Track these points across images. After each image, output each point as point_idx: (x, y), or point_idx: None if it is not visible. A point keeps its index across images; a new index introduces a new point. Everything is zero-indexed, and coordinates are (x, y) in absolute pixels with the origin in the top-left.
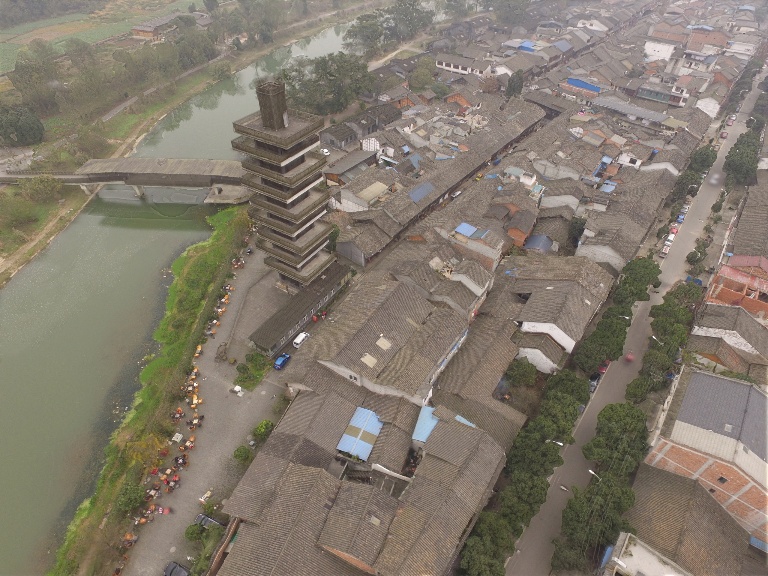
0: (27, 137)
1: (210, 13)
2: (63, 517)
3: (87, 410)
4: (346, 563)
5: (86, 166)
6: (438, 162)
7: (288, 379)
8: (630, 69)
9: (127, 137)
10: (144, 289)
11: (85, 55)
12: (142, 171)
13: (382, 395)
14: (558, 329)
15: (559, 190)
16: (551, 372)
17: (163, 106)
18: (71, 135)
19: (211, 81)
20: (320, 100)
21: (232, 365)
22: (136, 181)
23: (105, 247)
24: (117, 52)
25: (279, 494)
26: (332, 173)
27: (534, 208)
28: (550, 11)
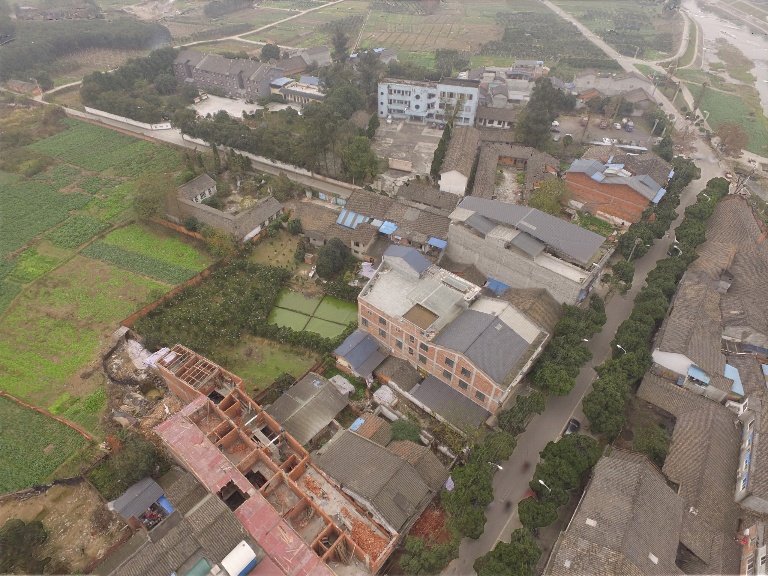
0: None
1: None
2: None
3: None
4: None
5: None
6: None
7: None
8: None
9: None
10: None
11: None
12: None
13: None
14: None
15: None
16: None
17: None
18: None
19: None
20: None
21: None
22: None
23: None
24: None
25: None
26: None
27: None
28: None
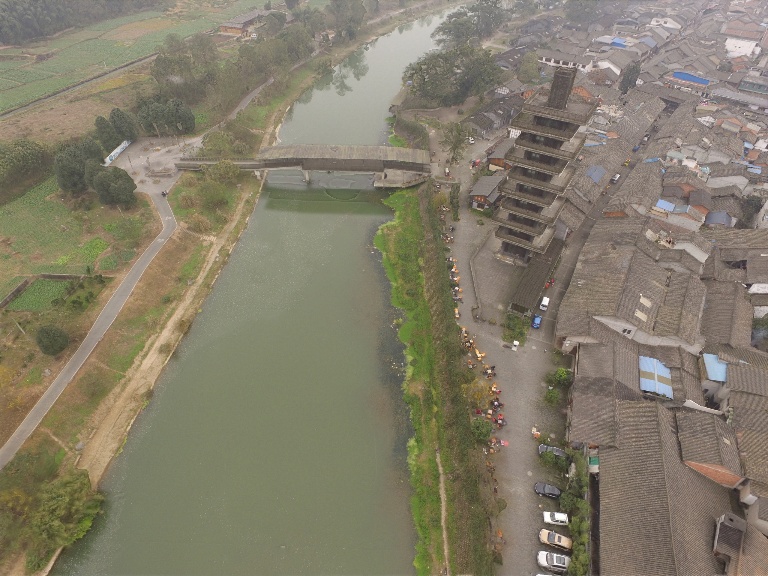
0: (183, 127)
1: (290, 11)
2: (397, 453)
3: (367, 366)
4: (705, 477)
5: (263, 152)
6: (589, 148)
7: (570, 333)
8: (717, 64)
9: (266, 127)
10: (359, 263)
11: (207, 50)
12: (321, 156)
13: (656, 346)
14: None
15: (725, 172)
16: None
17: (284, 99)
18: (216, 125)
19: (316, 75)
20: (449, 92)
21: (493, 325)
22: (313, 166)
23: (302, 226)
24: (244, 47)
25: (621, 424)
26: (499, 158)
27: (706, 188)
28: (614, 10)
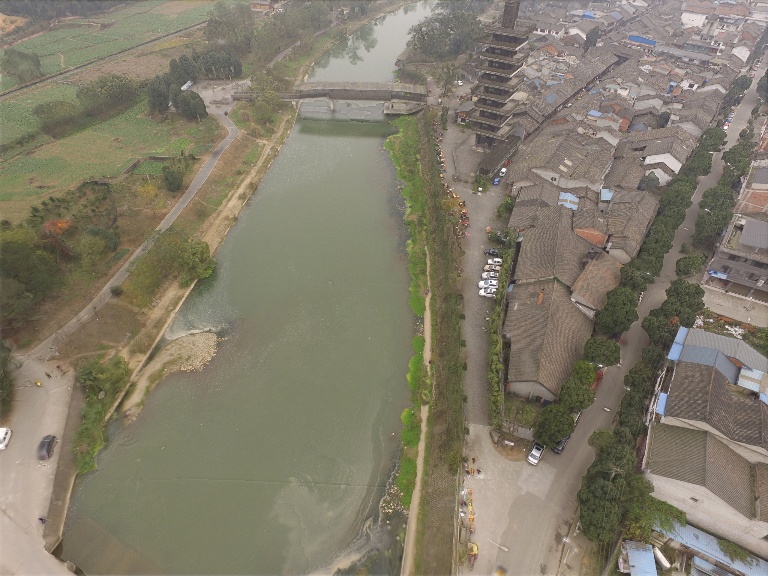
0: (233, 72)
1: None
2: (400, 247)
3: (380, 208)
4: (587, 240)
5: (299, 86)
6: None
7: (516, 179)
8: (672, 33)
9: (296, 76)
10: (373, 157)
11: (246, 17)
12: (344, 88)
13: (572, 188)
14: (671, 157)
15: (647, 97)
16: (666, 184)
17: (309, 57)
18: None
19: (334, 41)
20: (444, 49)
21: (466, 183)
22: (337, 96)
23: (330, 136)
24: (277, 13)
25: (539, 217)
26: None
27: (632, 108)
28: None
